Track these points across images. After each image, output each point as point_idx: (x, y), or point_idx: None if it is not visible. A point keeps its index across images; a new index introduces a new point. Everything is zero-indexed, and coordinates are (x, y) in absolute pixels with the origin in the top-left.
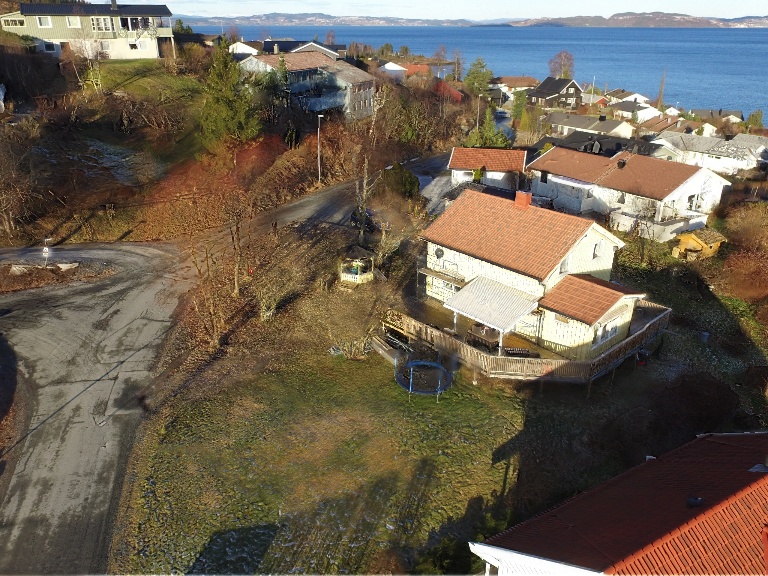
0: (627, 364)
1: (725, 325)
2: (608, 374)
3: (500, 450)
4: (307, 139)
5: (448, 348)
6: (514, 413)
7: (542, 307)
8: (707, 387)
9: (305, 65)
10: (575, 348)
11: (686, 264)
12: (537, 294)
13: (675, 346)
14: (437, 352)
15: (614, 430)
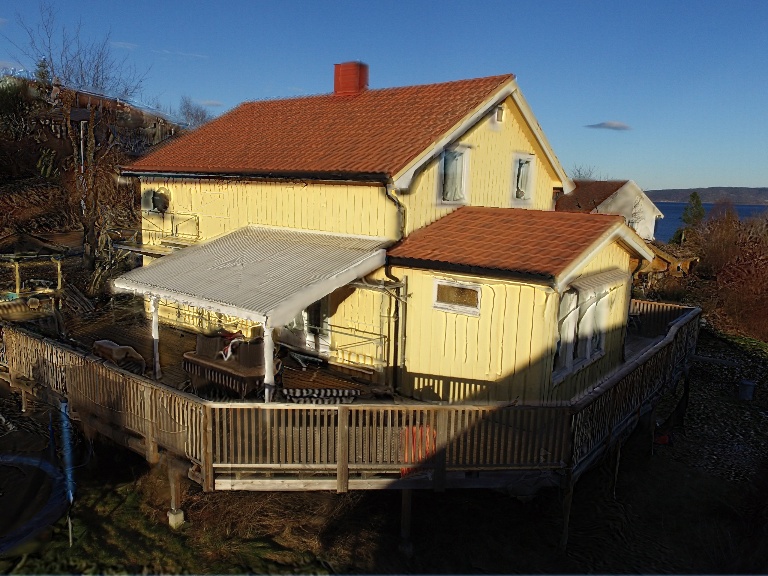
0: (630, 442)
1: (760, 374)
2: (605, 463)
3: None
4: (70, 162)
5: (97, 402)
6: None
7: (398, 264)
8: None
9: (96, 91)
10: (504, 380)
11: (654, 284)
12: (383, 235)
13: (697, 409)
14: (77, 424)
15: None
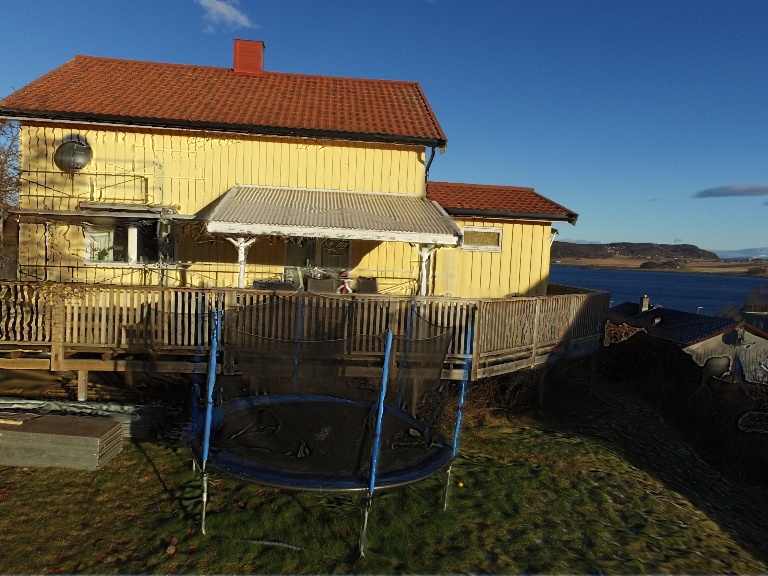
0: None
1: None
2: None
3: (762, 558)
4: None
5: (296, 339)
6: (595, 455)
7: None
8: (647, 341)
9: None
10: (526, 295)
11: None
12: (413, 192)
13: None
14: (237, 379)
15: (708, 423)
